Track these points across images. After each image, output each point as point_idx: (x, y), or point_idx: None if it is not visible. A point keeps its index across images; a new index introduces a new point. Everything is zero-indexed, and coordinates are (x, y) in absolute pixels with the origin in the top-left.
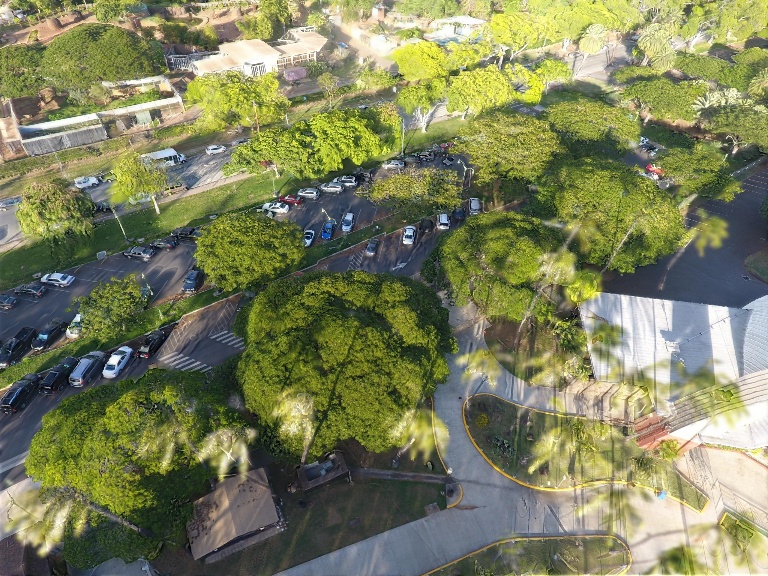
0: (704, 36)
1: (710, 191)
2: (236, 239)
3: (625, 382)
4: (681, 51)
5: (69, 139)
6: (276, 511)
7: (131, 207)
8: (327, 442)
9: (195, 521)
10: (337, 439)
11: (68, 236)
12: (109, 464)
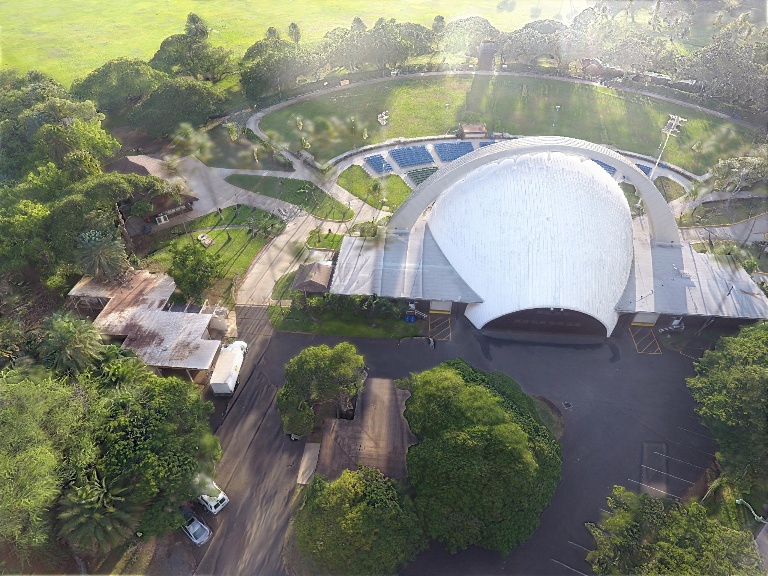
0: None
1: None
2: None
3: (713, 254)
4: None
5: None
6: None
7: None
8: None
9: None
10: None
11: None
12: None
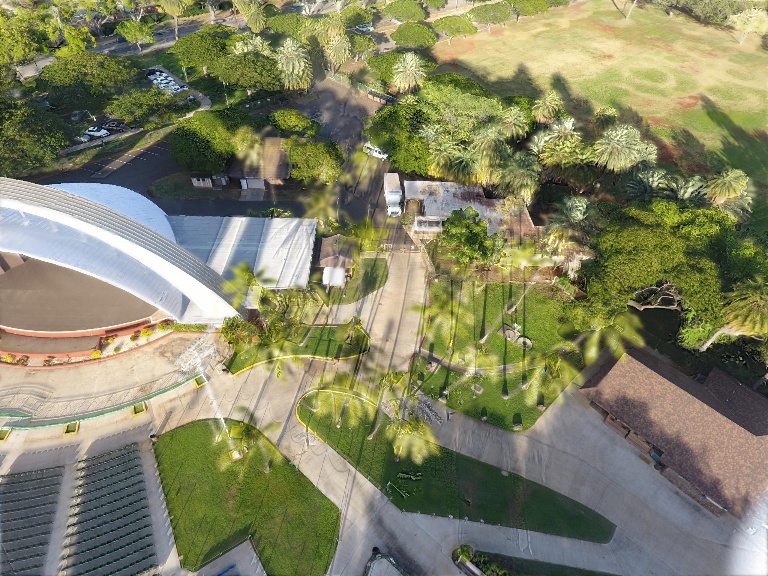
0: (368, 2)
1: (140, 122)
2: None
3: None
4: (328, 15)
5: None
6: None
7: None
8: None
9: None
10: None
11: None
12: None
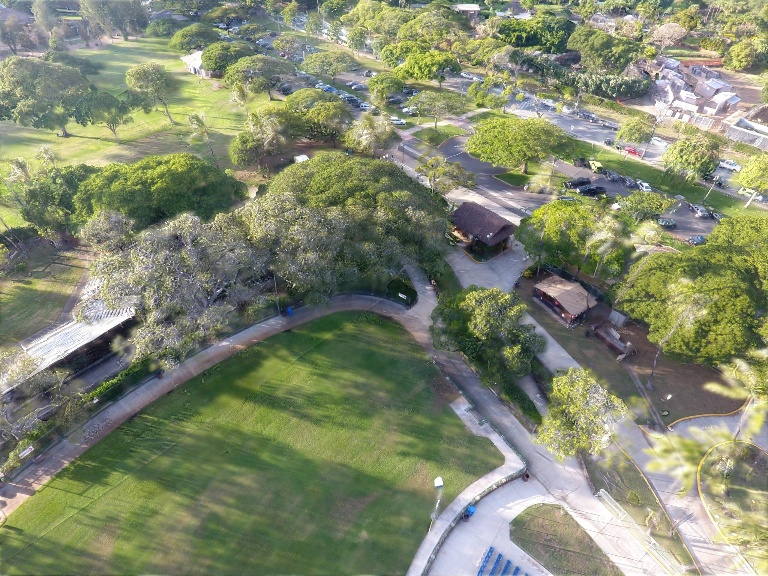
0: None
1: None
2: (759, 228)
3: None
4: None
5: (762, 142)
6: (576, 318)
7: (735, 193)
8: (637, 310)
9: (551, 281)
10: (643, 317)
11: (678, 172)
12: (564, 215)
